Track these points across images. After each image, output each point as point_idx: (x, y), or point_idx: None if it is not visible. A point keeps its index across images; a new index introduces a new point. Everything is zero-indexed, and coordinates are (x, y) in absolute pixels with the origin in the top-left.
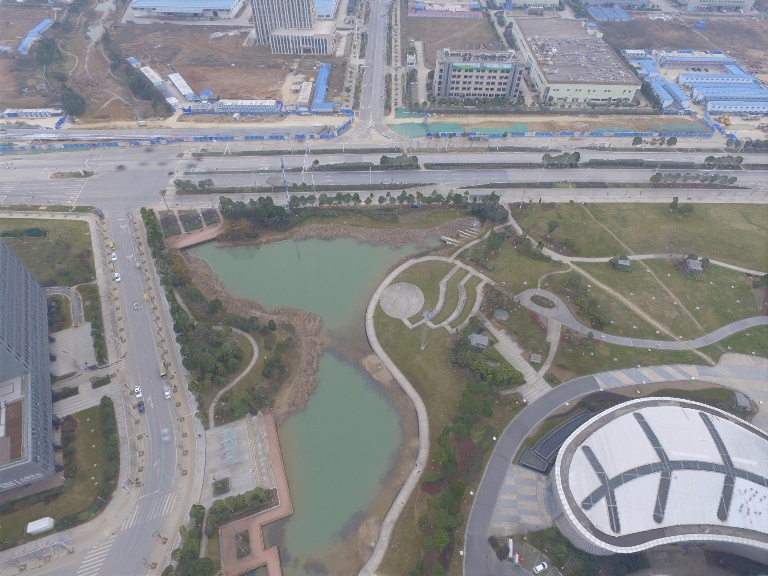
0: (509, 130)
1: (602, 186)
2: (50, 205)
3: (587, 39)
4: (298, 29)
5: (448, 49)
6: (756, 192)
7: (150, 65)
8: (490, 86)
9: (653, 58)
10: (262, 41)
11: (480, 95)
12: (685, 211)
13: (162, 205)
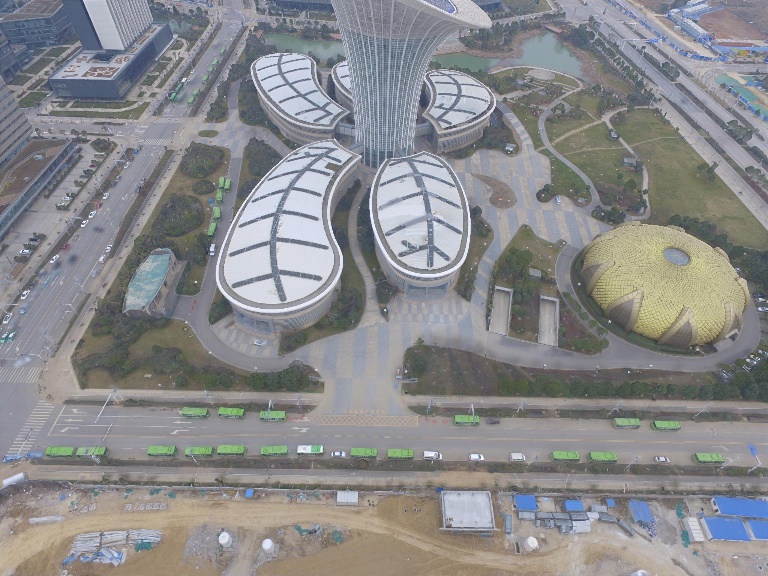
0: None
1: (718, 150)
2: (558, 2)
3: None
4: None
5: None
6: None
7: (715, 2)
8: None
9: None
10: None
11: None
12: None
13: (575, 21)
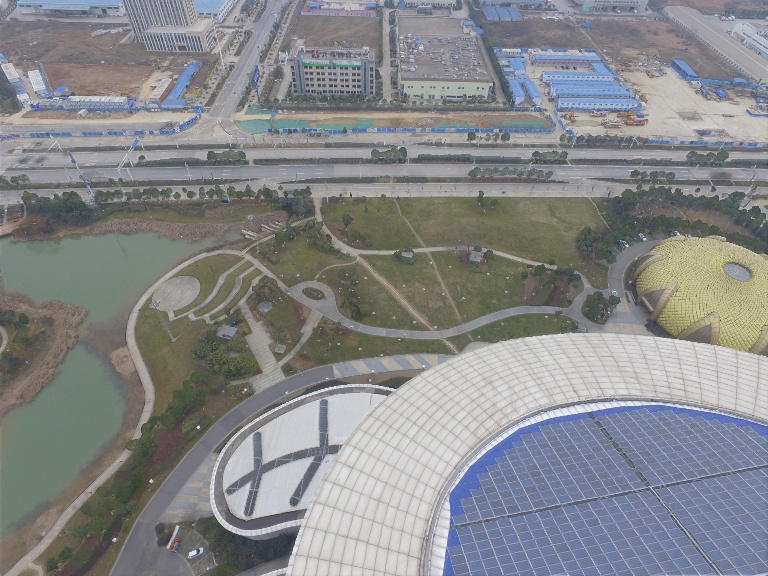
0: (354, 126)
1: (422, 181)
2: None
3: (460, 37)
4: (174, 26)
5: (303, 46)
6: (573, 186)
7: (17, 62)
8: (345, 83)
9: (527, 56)
10: (140, 38)
11: (337, 92)
12: (491, 205)
13: None
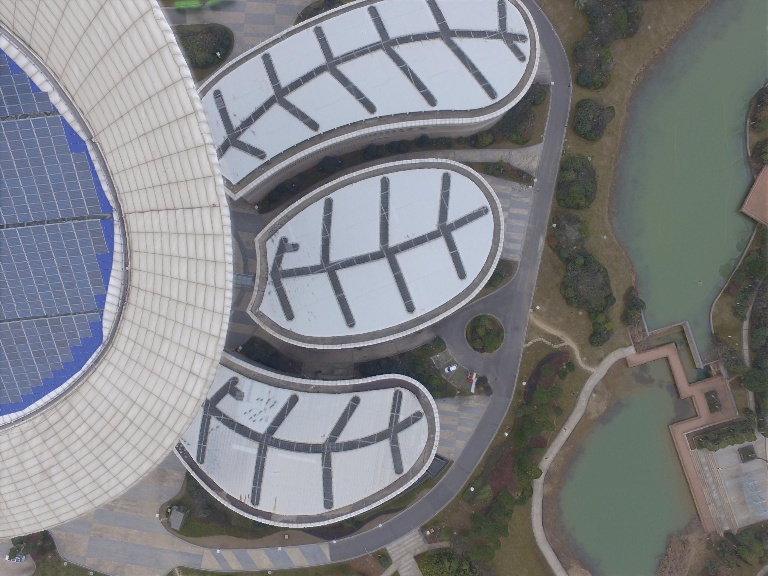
0: None
1: None
2: None
3: None
4: None
5: None
6: None
7: None
8: None
9: None
10: None
11: None
12: None
13: None
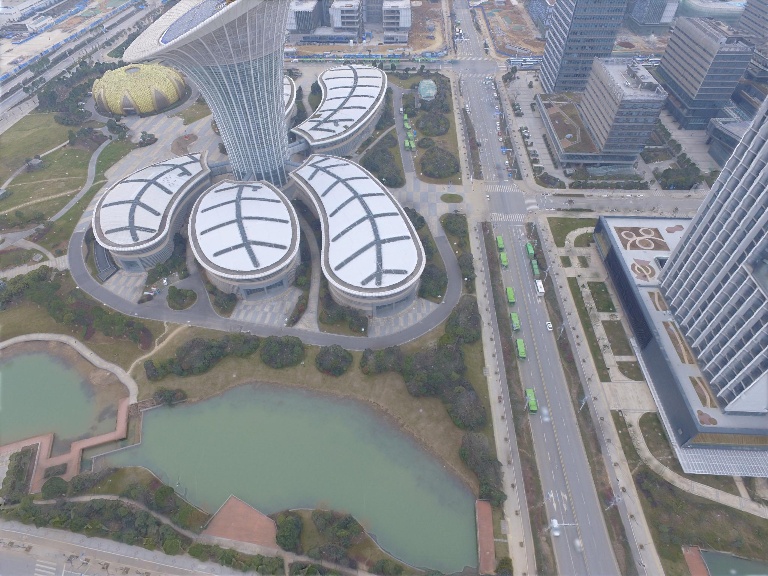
0: None
1: None
2: None
3: None
4: None
5: None
6: (8, 118)
7: None
8: None
9: None
10: None
11: None
12: None
13: None
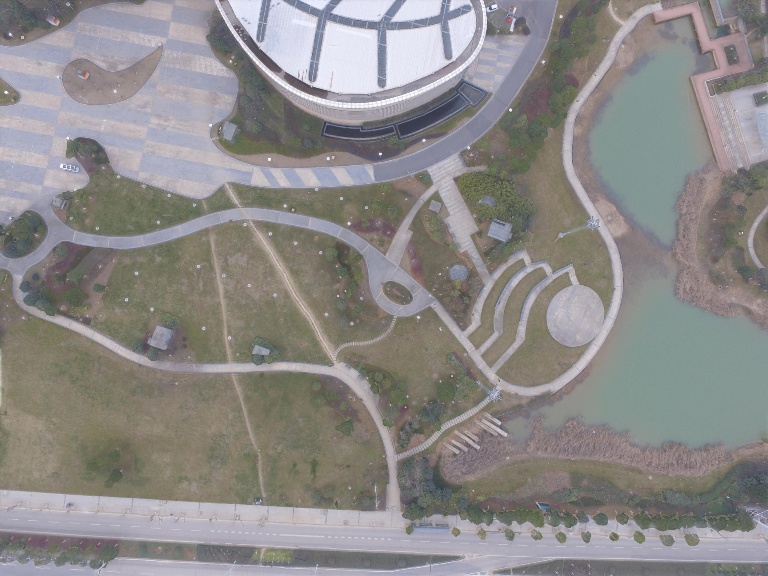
0: None
1: (207, 549)
2: None
3: None
4: None
5: None
6: None
7: None
8: None
9: None
10: None
11: None
12: None
13: None
